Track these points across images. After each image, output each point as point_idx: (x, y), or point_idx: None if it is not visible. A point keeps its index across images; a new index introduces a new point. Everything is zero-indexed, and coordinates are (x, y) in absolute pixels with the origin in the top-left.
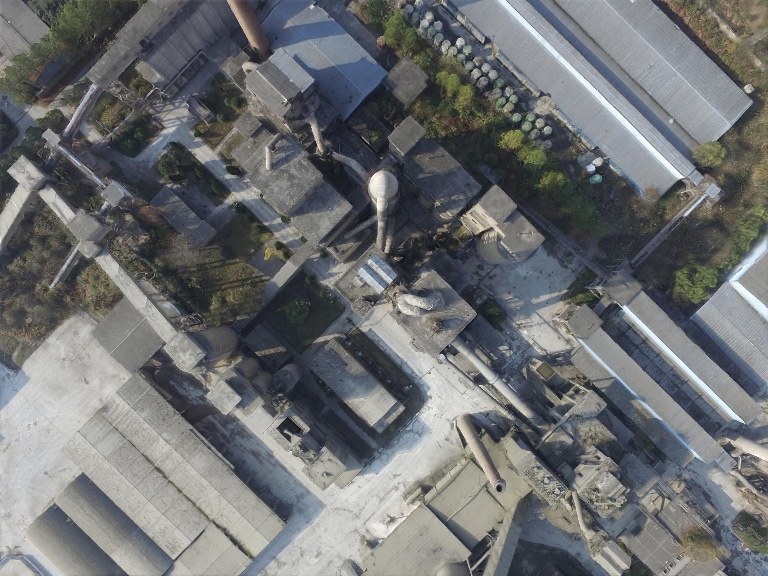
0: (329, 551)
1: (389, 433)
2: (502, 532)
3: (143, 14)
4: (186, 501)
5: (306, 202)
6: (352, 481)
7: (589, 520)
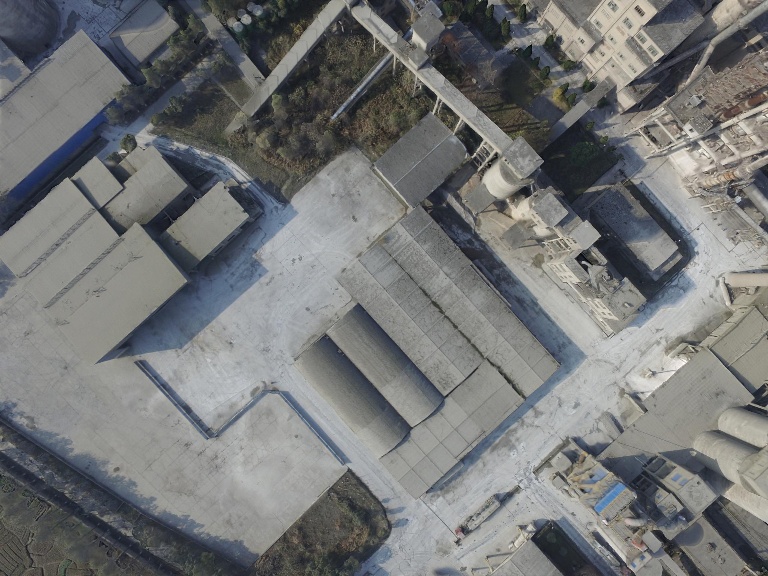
0: (587, 403)
1: None
2: None
3: None
4: (461, 337)
5: (660, 12)
6: (615, 333)
7: None
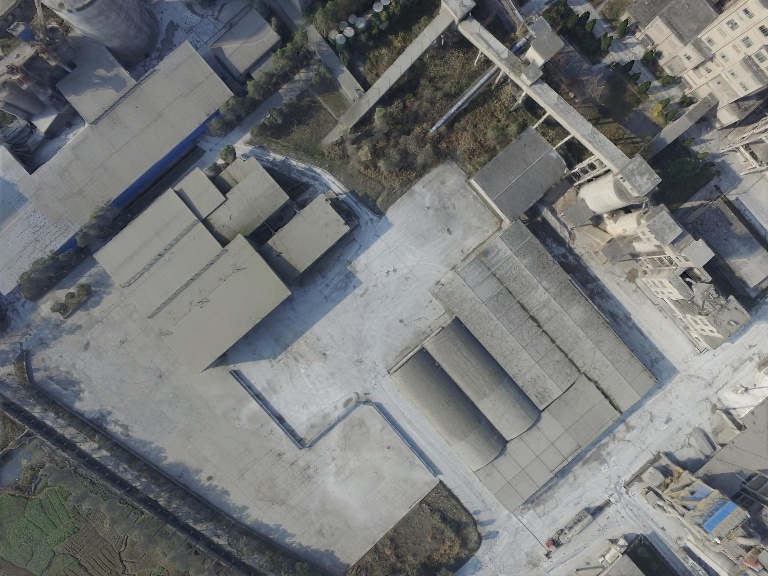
0: (679, 418)
1: None
2: None
3: None
4: (559, 352)
5: None
6: (707, 349)
7: None
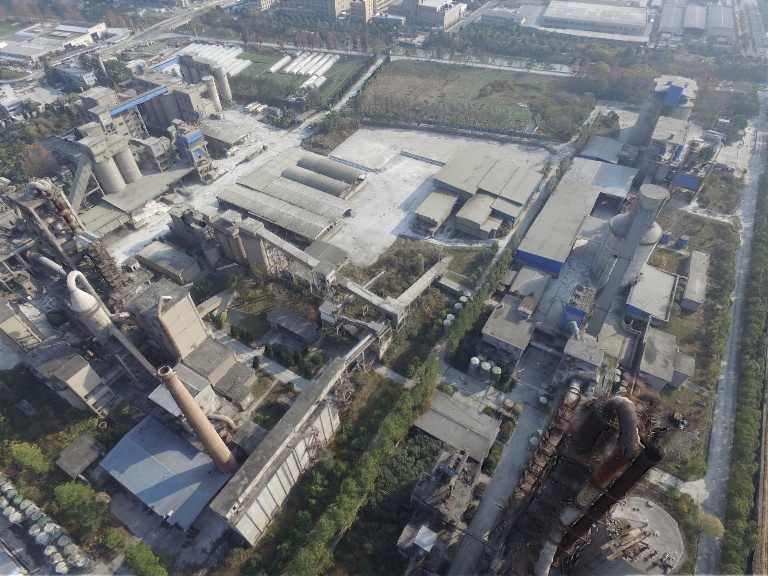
0: (198, 198)
1: None
2: (77, 204)
3: (300, 413)
4: (276, 196)
5: None
6: None
7: (14, 207)
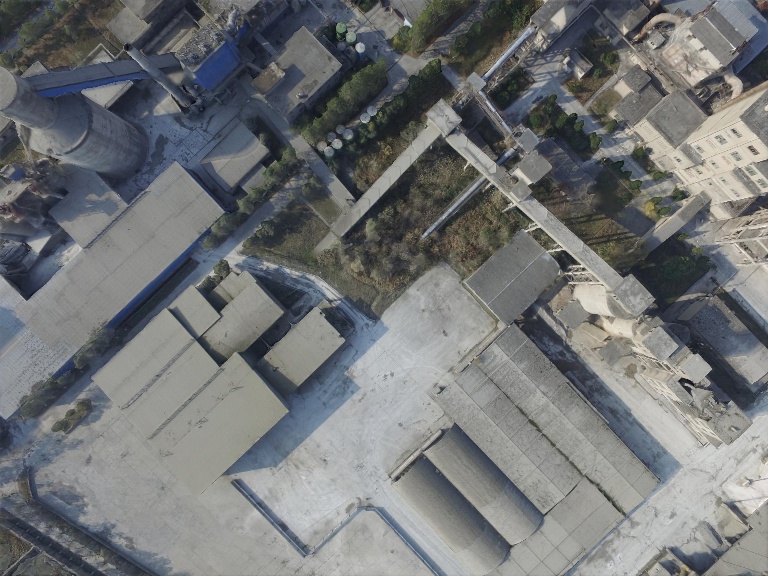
0: (684, 512)
1: (750, 394)
2: None
3: None
4: (559, 455)
5: None
6: None
7: None
